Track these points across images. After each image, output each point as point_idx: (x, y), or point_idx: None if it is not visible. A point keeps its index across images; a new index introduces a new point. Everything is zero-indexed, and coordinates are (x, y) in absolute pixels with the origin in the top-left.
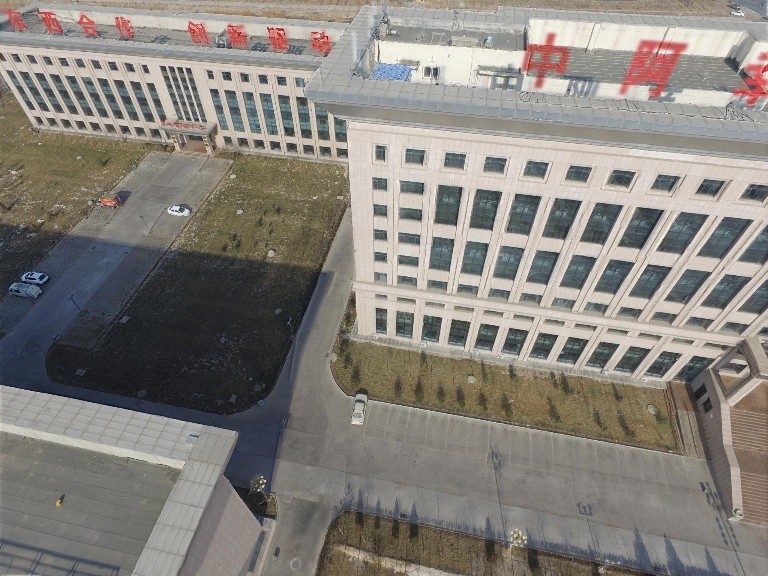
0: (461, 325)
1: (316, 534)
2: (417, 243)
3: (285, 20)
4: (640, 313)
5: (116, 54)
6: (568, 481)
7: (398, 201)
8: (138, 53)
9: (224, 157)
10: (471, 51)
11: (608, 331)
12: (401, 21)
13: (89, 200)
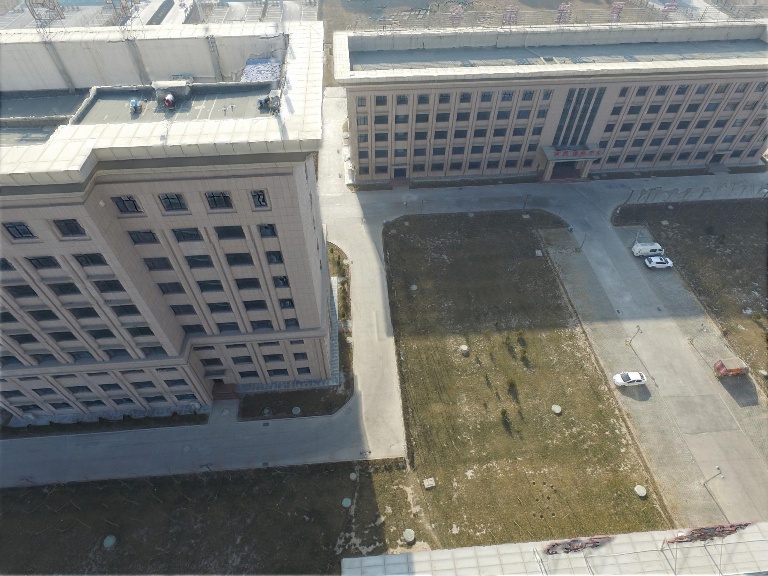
0: None
1: (323, 184)
2: None
3: None
4: None
5: None
6: None
7: None
8: None
9: None
10: None
11: None
12: None
13: None
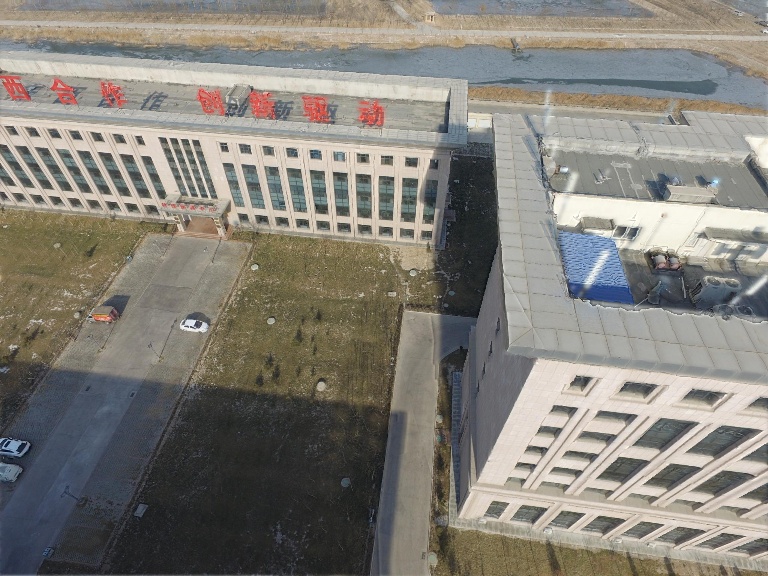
0: (608, 518)
1: None
2: (586, 457)
3: (309, 72)
4: None
5: (101, 124)
6: None
7: (583, 427)
8: (131, 124)
9: (240, 239)
10: (701, 210)
11: None
12: (559, 143)
13: (75, 311)
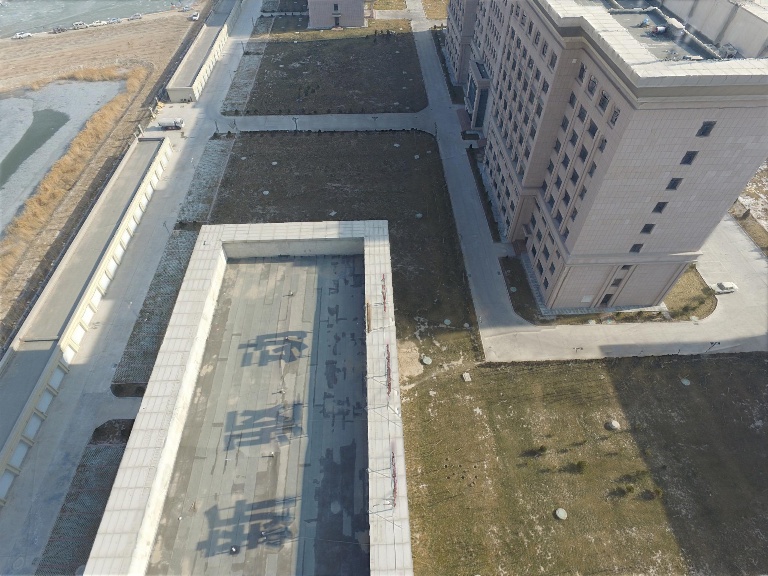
0: None
1: None
2: None
3: (132, 472)
4: None
5: None
6: None
7: None
8: None
9: None
10: None
11: None
12: None
13: None
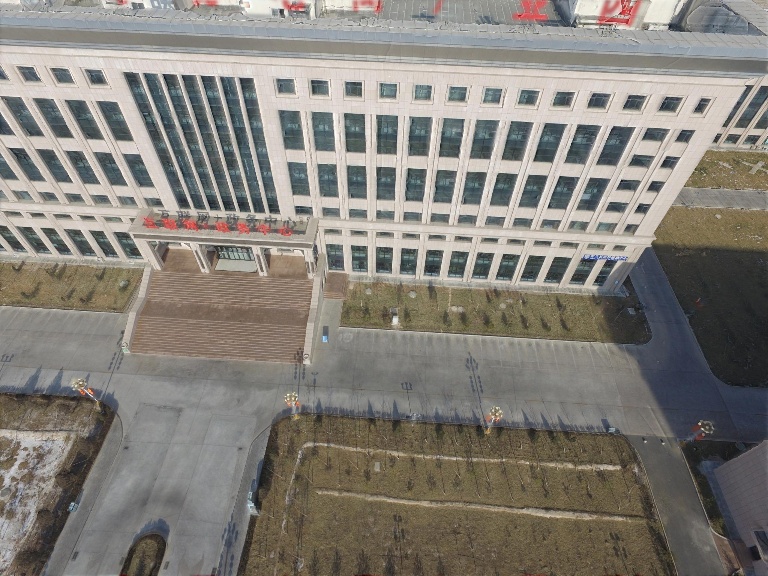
0: None
1: None
2: None
3: None
4: (56, 196)
5: None
6: (8, 340)
7: None
8: None
9: None
10: None
11: (60, 218)
12: None
13: None
